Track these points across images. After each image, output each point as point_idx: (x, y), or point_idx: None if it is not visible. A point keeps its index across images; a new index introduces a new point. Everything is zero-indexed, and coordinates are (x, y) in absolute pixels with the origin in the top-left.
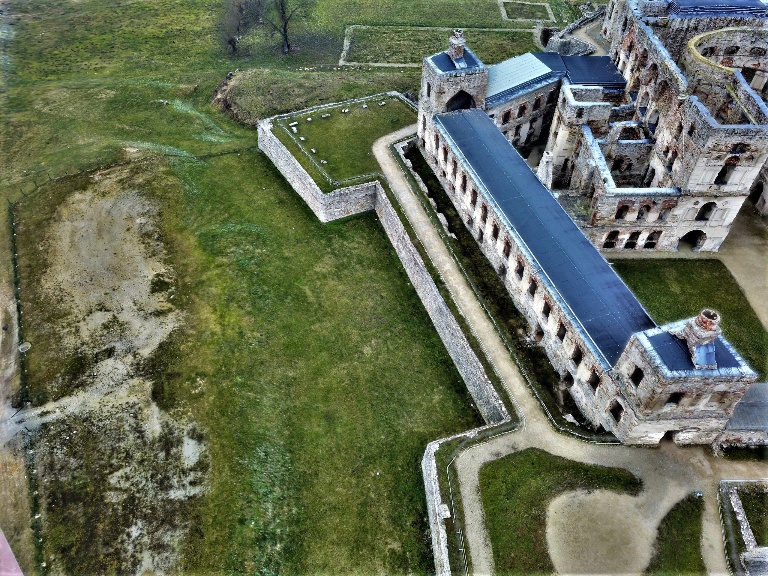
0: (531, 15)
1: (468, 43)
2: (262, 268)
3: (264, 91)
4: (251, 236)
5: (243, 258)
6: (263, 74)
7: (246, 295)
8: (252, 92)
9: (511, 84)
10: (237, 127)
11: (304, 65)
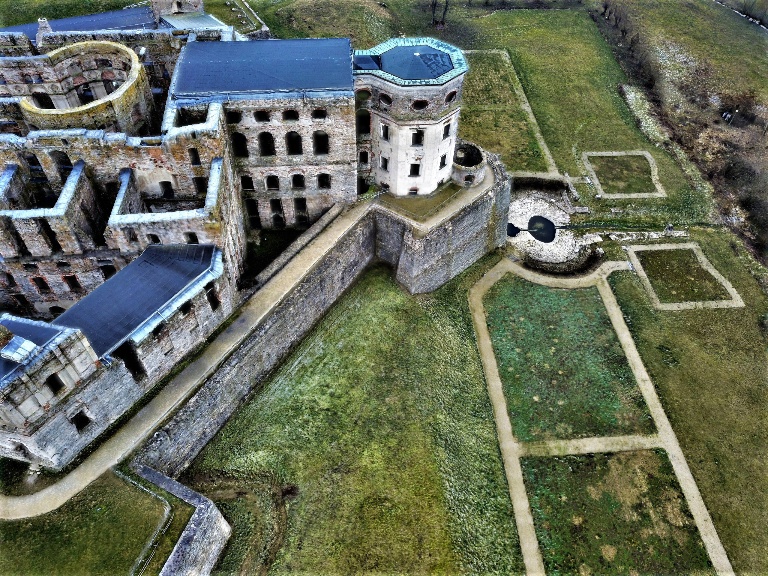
0: (610, 176)
1: (493, 121)
2: (82, 8)
3: (322, 5)
4: (115, 4)
5: (91, 1)
6: (354, 4)
7: (57, 3)
8: (319, 1)
9: (181, 27)
10: (281, 7)
11: (410, 34)
